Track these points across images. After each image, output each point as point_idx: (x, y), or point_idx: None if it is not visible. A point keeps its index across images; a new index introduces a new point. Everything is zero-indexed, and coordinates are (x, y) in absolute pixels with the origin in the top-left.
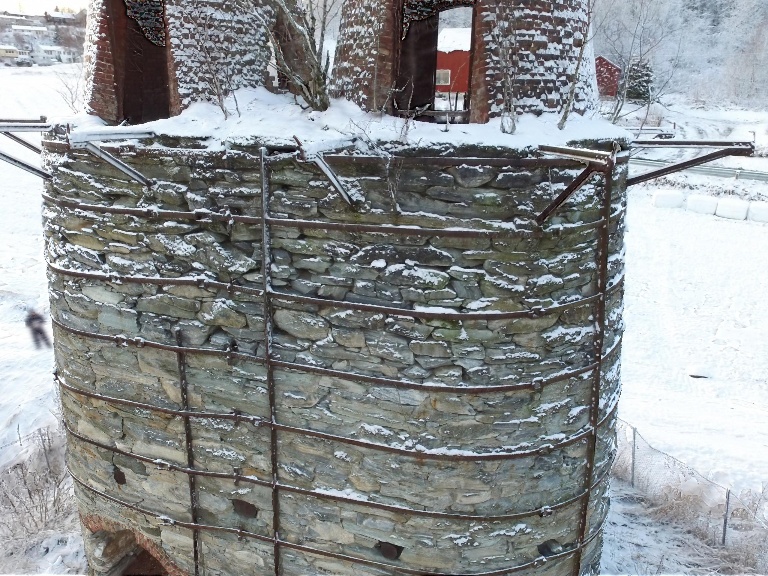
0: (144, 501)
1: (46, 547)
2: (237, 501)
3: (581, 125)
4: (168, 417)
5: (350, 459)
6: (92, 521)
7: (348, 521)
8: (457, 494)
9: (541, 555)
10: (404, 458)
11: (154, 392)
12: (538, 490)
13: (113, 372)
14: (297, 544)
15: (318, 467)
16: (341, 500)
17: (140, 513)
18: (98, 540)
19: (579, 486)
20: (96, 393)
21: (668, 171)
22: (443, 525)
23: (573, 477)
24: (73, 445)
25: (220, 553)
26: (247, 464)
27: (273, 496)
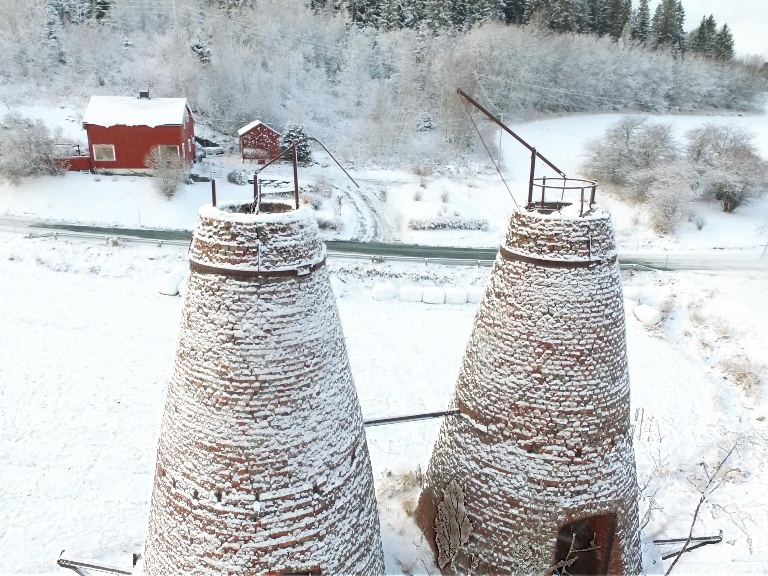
0: None
1: None
2: None
3: (658, 575)
4: None
5: None
6: None
7: None
8: None
9: None
10: None
11: None
12: None
13: None
14: None
15: None
16: None
17: None
18: None
19: None
20: None
21: (672, 555)
22: None
23: None
24: None
25: None
26: None
27: None
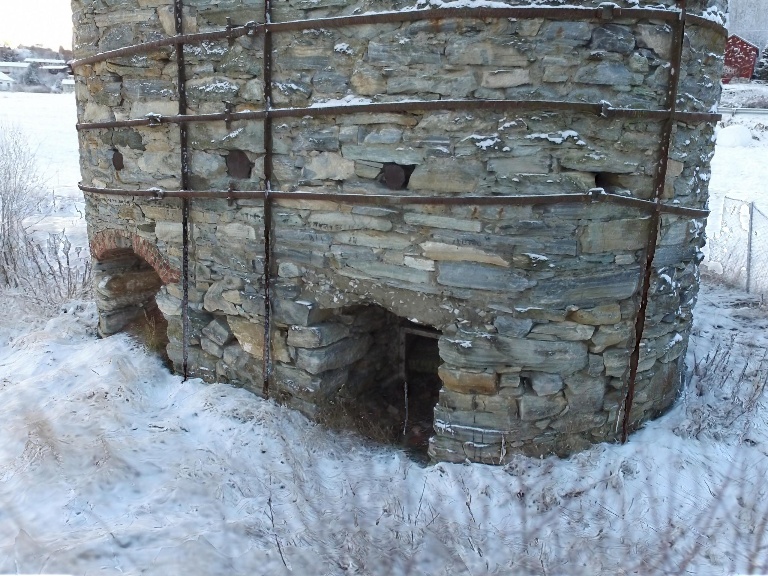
0: (140, 188)
1: (64, 309)
2: (230, 157)
3: None
4: (163, 57)
5: (352, 51)
6: (97, 243)
7: (348, 144)
8: (482, 73)
9: (599, 187)
10: (415, 25)
11: (150, 28)
12: (596, 79)
13: (113, 17)
14: (290, 191)
15: (316, 75)
16: (340, 111)
17: (136, 206)
18: (105, 274)
19: (658, 105)
20: (98, 53)
21: None
22: (463, 120)
23: (649, 82)
24: (81, 143)
25: (211, 233)
26: (240, 97)
27: (265, 126)
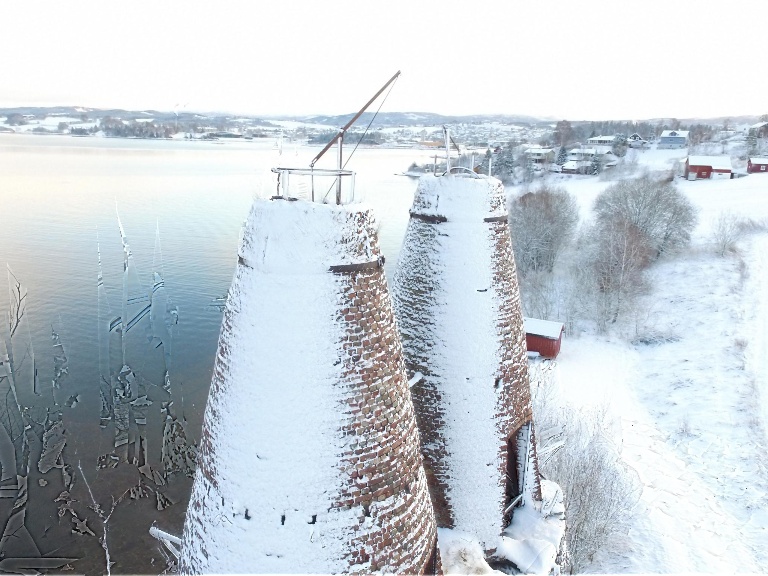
0: None
1: None
2: None
3: None
4: None
5: None
6: None
7: None
8: None
9: None
10: None
11: None
12: None
13: None
14: None
15: None
16: None
17: None
18: None
19: None
20: None
21: None
22: None
23: None
24: None
25: None
26: None
27: None
